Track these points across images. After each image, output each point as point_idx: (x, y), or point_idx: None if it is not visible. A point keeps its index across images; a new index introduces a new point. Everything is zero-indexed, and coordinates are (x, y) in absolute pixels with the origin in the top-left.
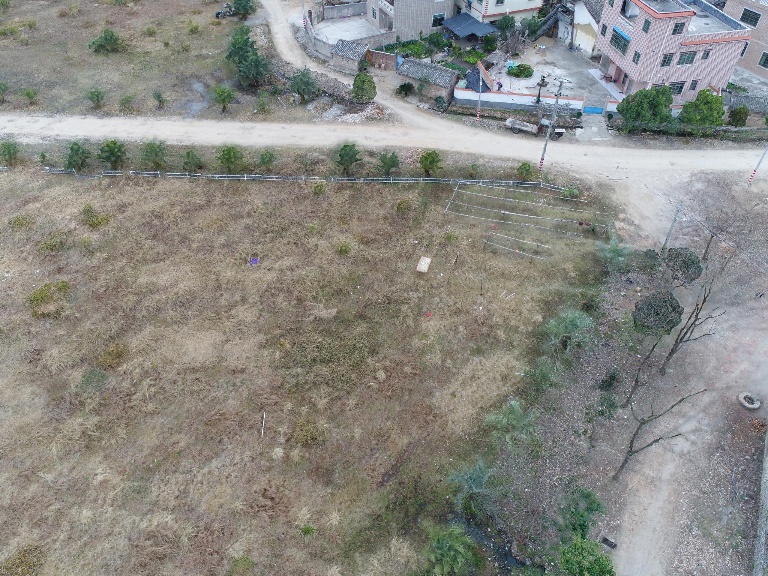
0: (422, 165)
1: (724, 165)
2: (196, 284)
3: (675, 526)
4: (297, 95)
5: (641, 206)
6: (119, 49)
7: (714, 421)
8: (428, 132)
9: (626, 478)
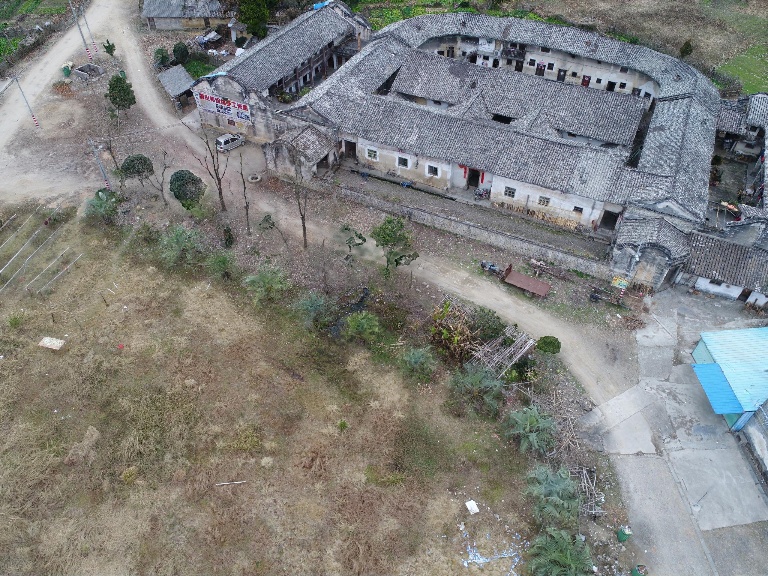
0: None
1: (6, 133)
2: None
3: (337, 227)
4: None
5: (34, 188)
6: None
7: (267, 197)
8: None
9: None
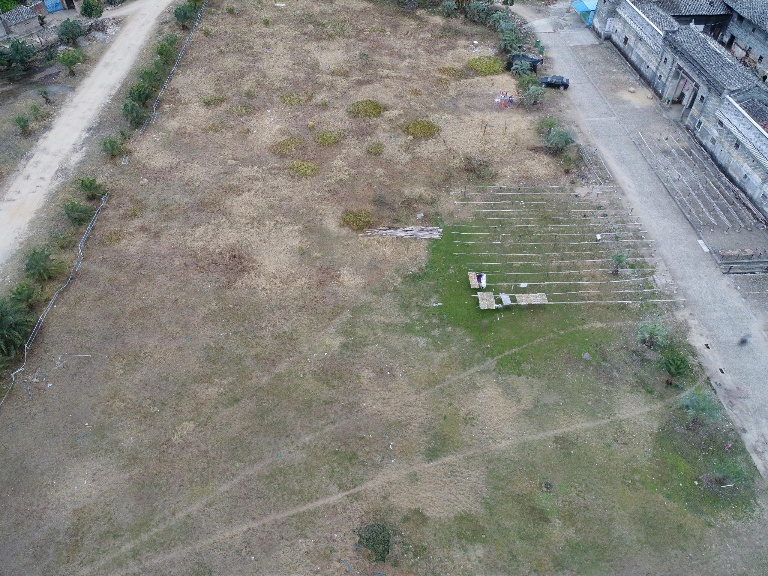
0: (194, 2)
1: None
2: None
3: None
4: (65, 47)
5: None
6: None
7: None
8: (145, 8)
9: None
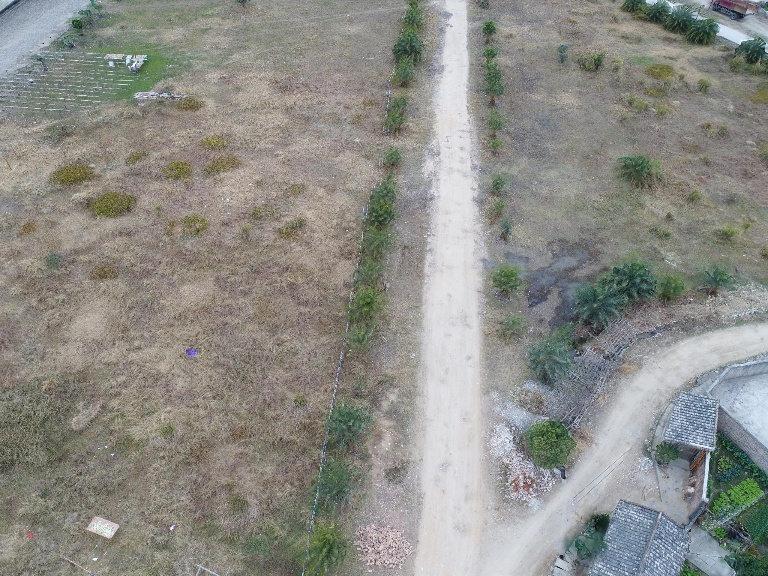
0: None
1: None
2: (171, 311)
3: None
4: None
5: None
6: (634, 181)
7: None
8: (469, 570)
9: None
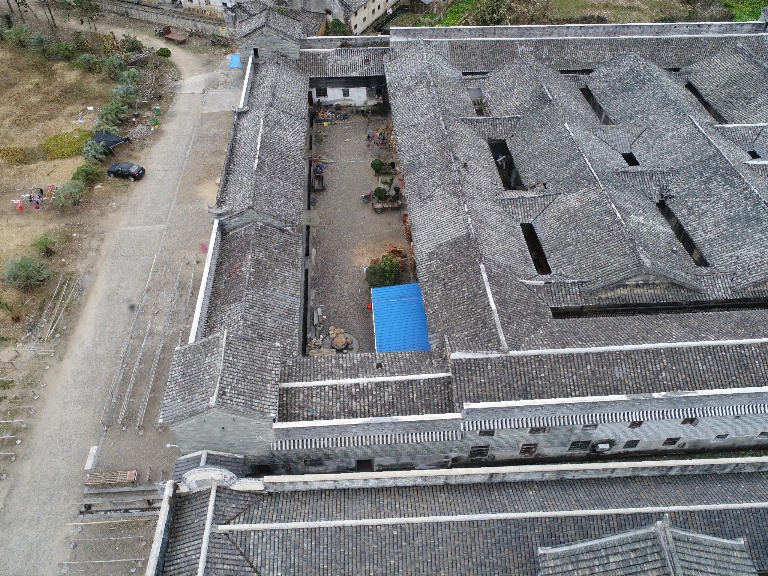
0: None
1: None
2: None
3: None
4: None
5: None
6: None
7: (44, 8)
8: None
9: (57, 25)
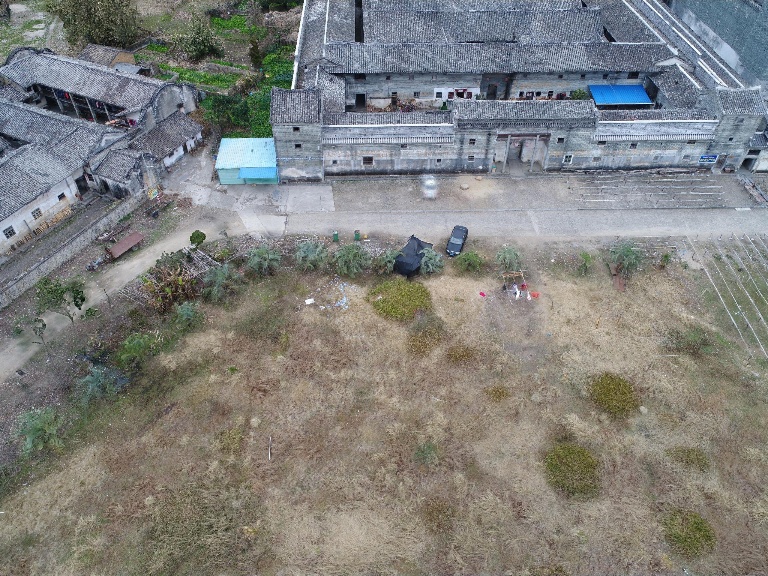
0: None
1: None
2: None
3: None
4: None
5: None
6: None
7: None
8: None
9: None
